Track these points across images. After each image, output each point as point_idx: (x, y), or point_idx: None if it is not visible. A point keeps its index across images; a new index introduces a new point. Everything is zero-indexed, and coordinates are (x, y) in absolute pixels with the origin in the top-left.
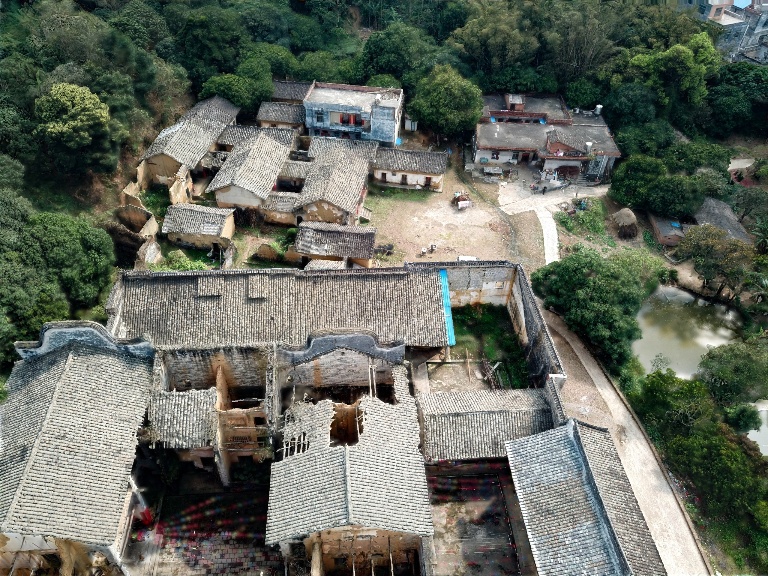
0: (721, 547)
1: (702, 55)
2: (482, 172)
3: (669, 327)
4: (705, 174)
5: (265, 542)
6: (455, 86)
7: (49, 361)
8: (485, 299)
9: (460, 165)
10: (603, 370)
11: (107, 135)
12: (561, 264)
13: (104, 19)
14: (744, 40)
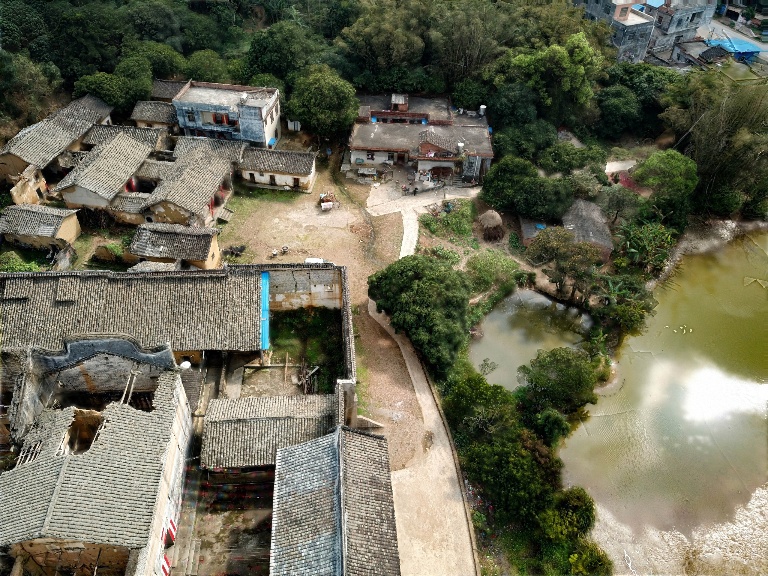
0: (508, 557)
1: (578, 55)
2: (357, 173)
3: (516, 331)
4: (576, 176)
5: None
6: (325, 86)
7: None
8: (317, 302)
9: (337, 166)
10: (426, 375)
11: None
12: (392, 267)
13: None
14: (651, 41)
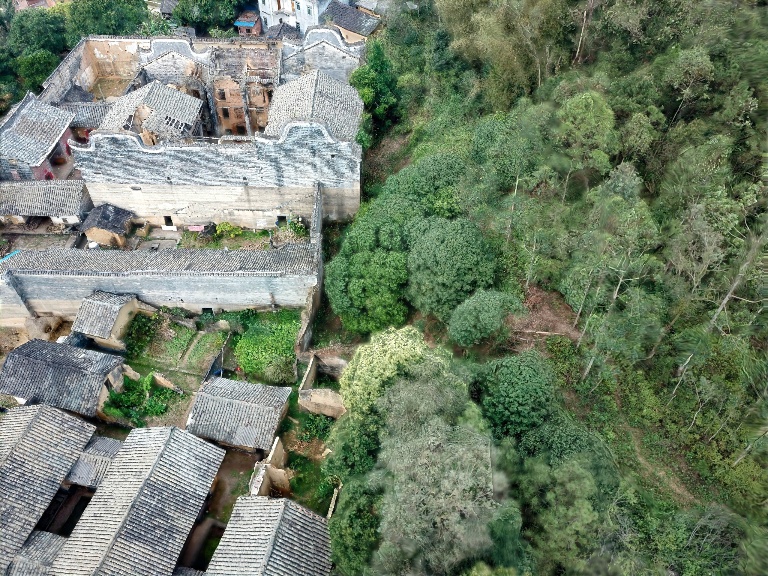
0: None
1: None
2: None
3: None
4: None
5: None
6: None
7: None
8: None
9: None
10: None
11: None
12: None
13: None
14: None
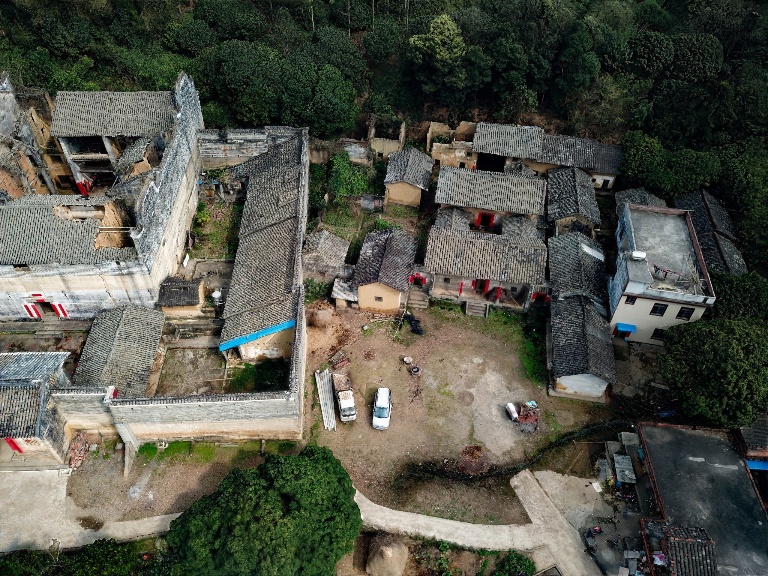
0: None
1: None
2: None
3: None
4: None
5: None
6: (718, 342)
7: None
8: None
9: None
10: None
11: (440, 71)
12: None
13: (641, 26)
14: None
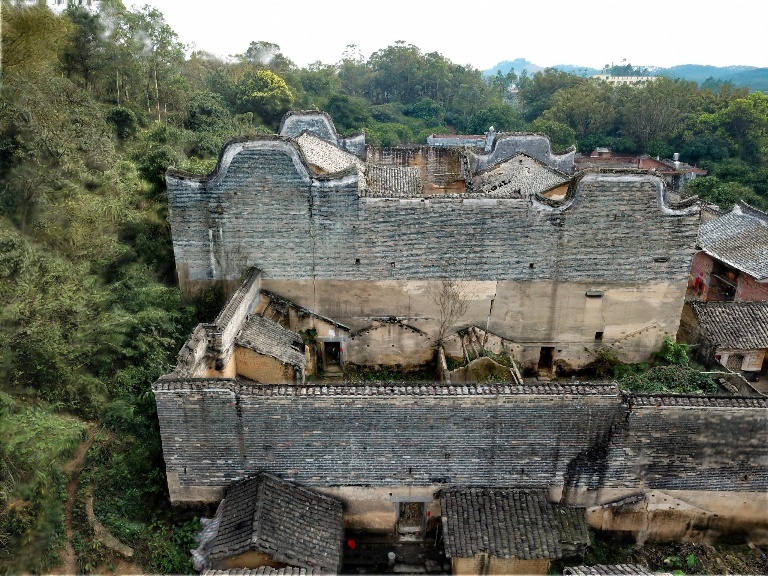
0: None
1: (761, 105)
2: None
3: None
4: None
5: None
6: (554, 125)
7: None
8: None
9: None
10: None
11: None
12: None
13: None
14: None
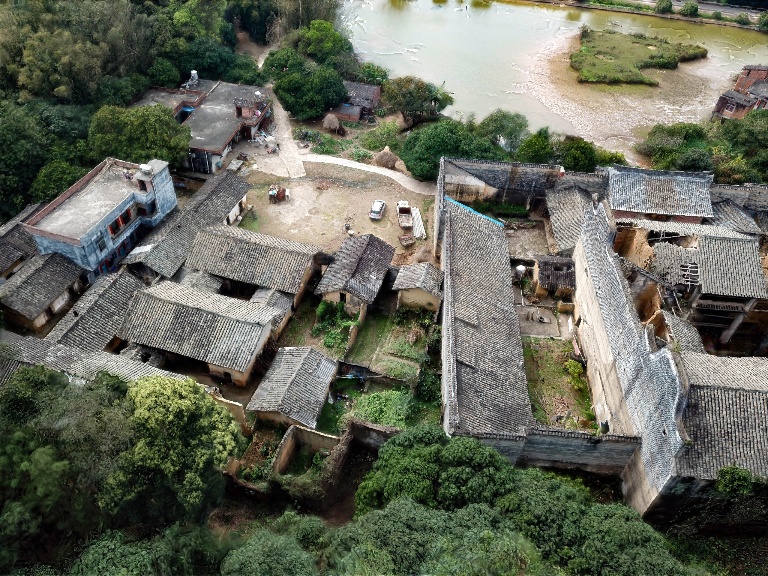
0: None
1: None
2: None
3: None
4: (311, 67)
5: (766, 298)
6: (159, 113)
7: (691, 415)
8: None
9: None
10: None
11: None
12: (433, 145)
13: None
14: None
